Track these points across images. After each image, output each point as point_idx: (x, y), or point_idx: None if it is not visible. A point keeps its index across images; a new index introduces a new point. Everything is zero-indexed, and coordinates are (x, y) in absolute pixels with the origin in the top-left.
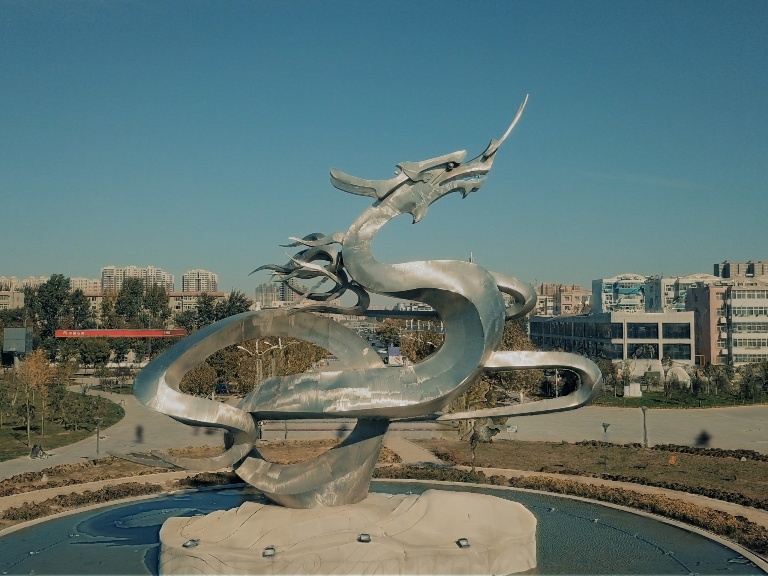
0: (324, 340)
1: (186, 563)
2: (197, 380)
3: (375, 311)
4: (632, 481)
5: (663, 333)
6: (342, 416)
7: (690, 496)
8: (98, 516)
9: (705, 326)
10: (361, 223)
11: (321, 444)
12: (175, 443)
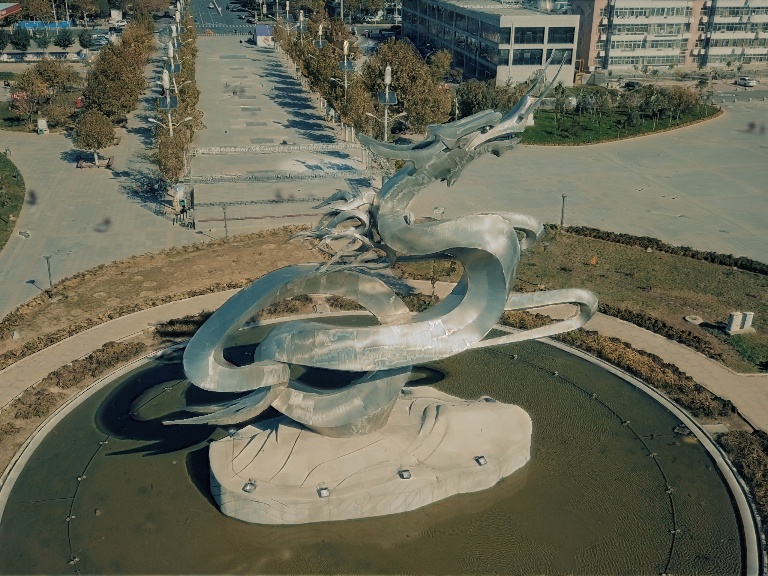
0: (354, 293)
1: (250, 506)
2: (94, 135)
3: None
4: None
5: (548, 38)
6: None
7: (621, 323)
8: (106, 402)
9: (587, 27)
10: (397, 192)
11: (260, 238)
12: (110, 244)
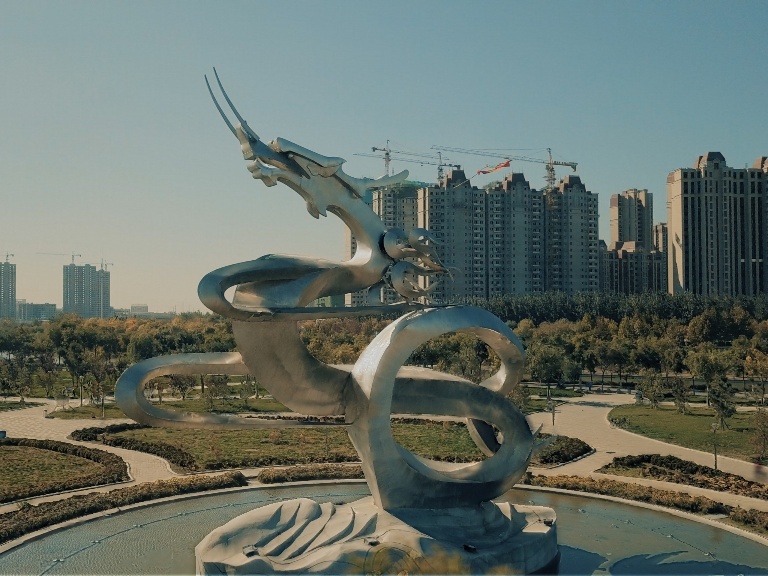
0: None
1: None
2: None
3: (371, 307)
4: None
5: None
6: None
7: None
8: None
9: None
10: None
11: None
12: None
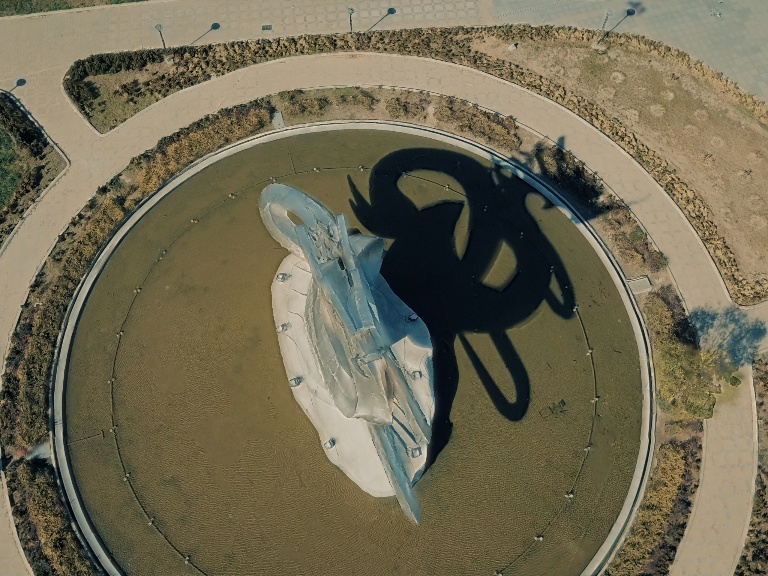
0: None
1: None
2: None
3: None
4: (735, 575)
5: None
6: None
7: None
8: (420, 150)
9: None
10: None
11: None
12: (756, 40)
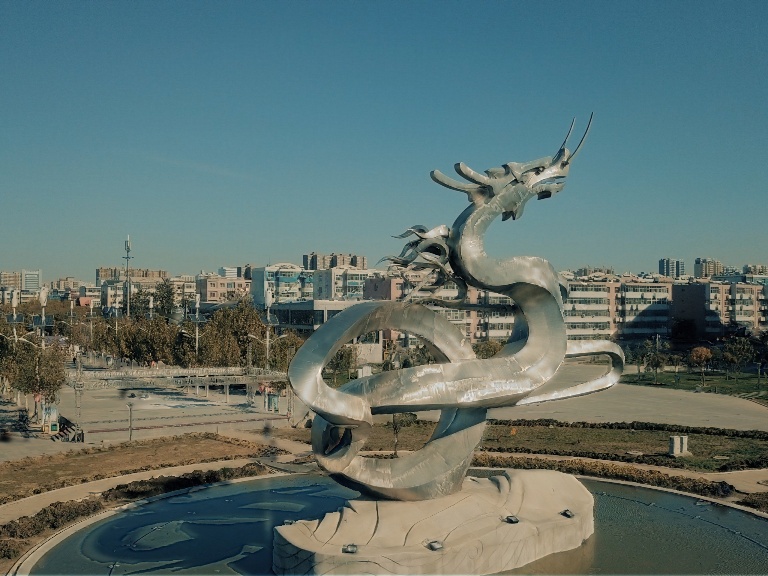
0: (430, 332)
1: (357, 569)
2: None
3: None
4: (519, 451)
5: None
6: (461, 406)
7: None
8: (88, 543)
9: None
10: (476, 219)
11: (165, 442)
12: None
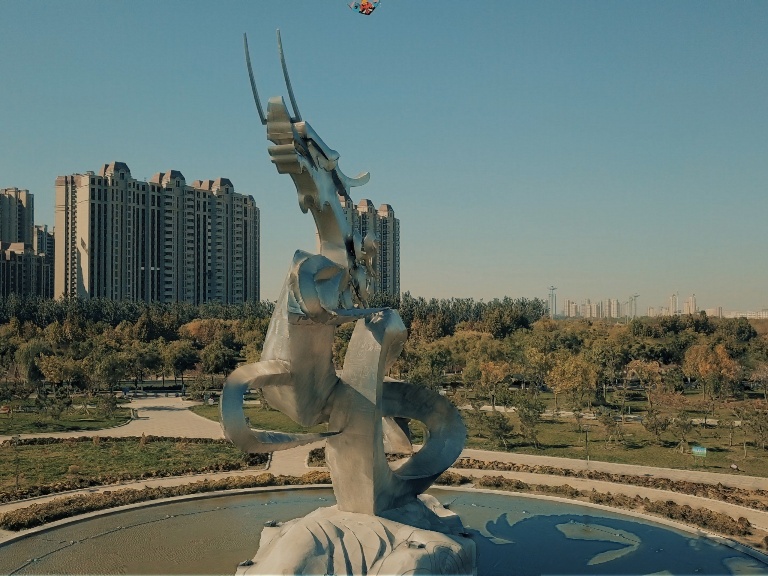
0: None
1: None
2: None
3: None
4: None
5: None
6: None
7: None
8: (607, 518)
9: None
10: None
11: None
12: None
